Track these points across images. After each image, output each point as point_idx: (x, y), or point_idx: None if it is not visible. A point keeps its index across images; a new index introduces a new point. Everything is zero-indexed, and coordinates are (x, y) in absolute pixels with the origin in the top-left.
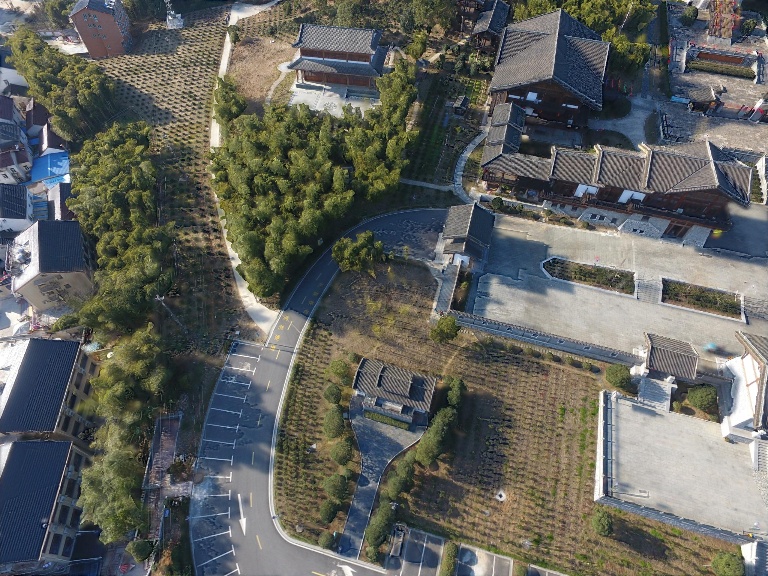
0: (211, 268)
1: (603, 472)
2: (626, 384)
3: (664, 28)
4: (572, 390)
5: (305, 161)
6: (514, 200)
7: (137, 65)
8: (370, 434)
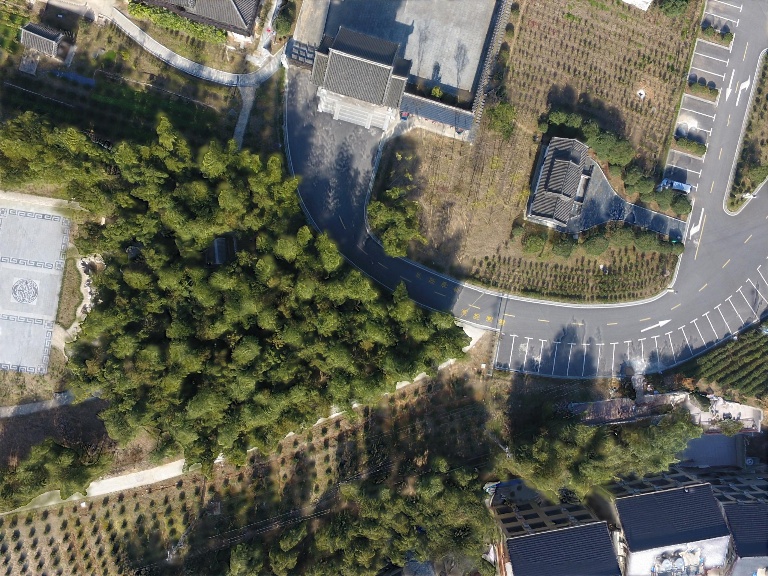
0: (389, 421)
1: None
2: None
3: None
4: (550, 0)
5: (249, 304)
6: (273, 1)
7: None
8: (593, 212)
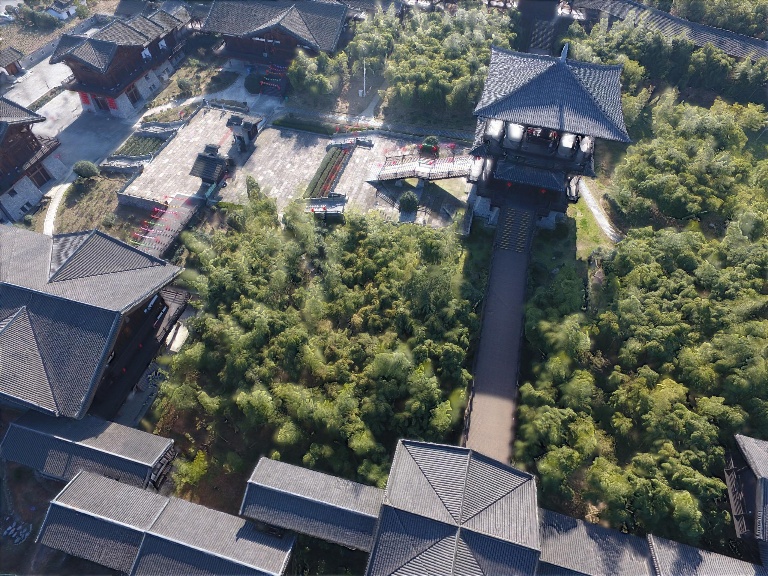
0: None
1: None
2: None
3: None
4: None
5: None
6: None
7: None
8: None
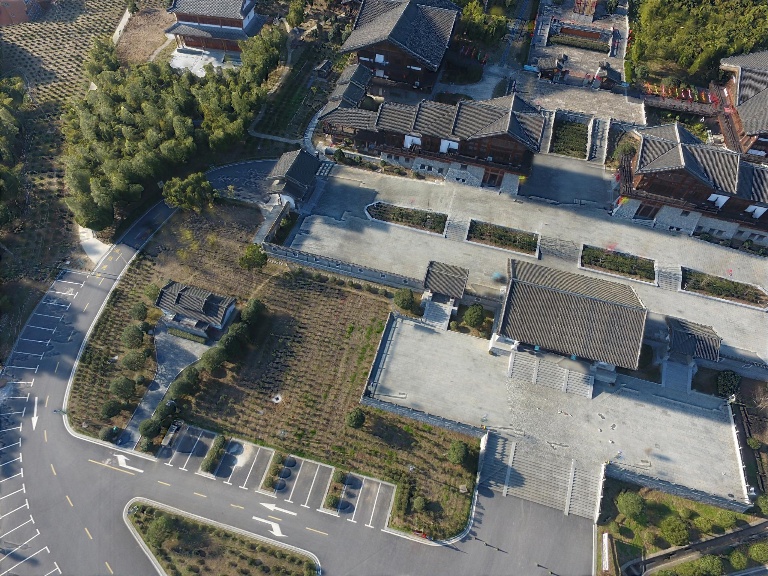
0: (58, 208)
1: (371, 378)
2: (409, 305)
3: (535, 6)
4: (364, 312)
5: (150, 110)
6: (356, 153)
7: (34, 31)
8: (169, 347)
